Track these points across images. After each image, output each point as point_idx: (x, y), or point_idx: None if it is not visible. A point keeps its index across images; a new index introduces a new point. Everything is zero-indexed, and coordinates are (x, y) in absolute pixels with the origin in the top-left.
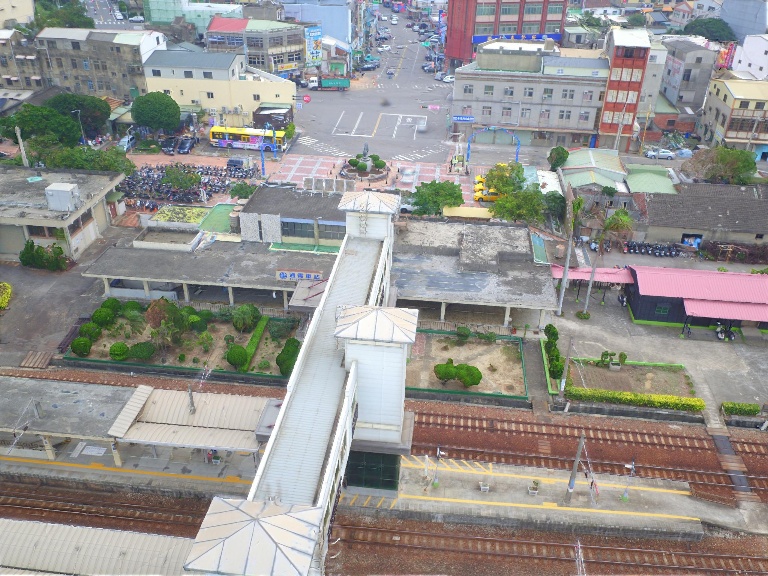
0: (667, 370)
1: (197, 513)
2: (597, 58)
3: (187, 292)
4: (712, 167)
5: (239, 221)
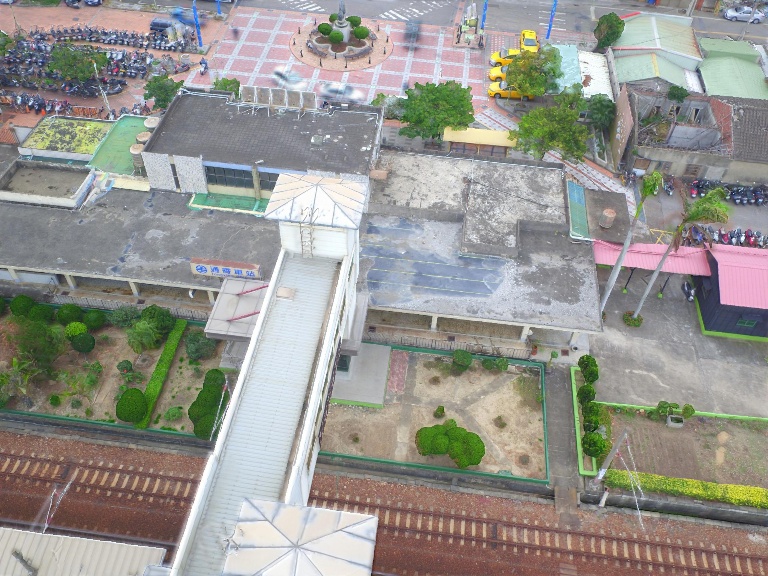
0: (748, 427)
1: None
2: None
3: (69, 278)
4: None
5: None
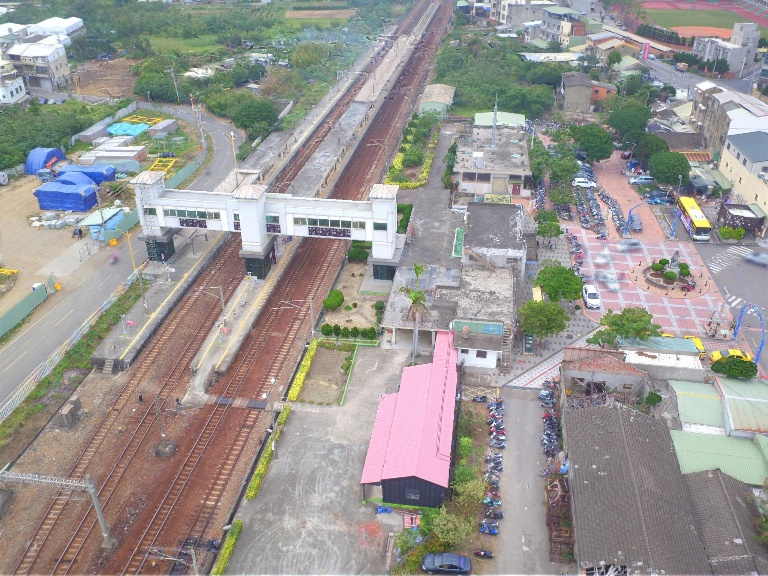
0: None
1: None
2: None
3: None
4: None
5: None
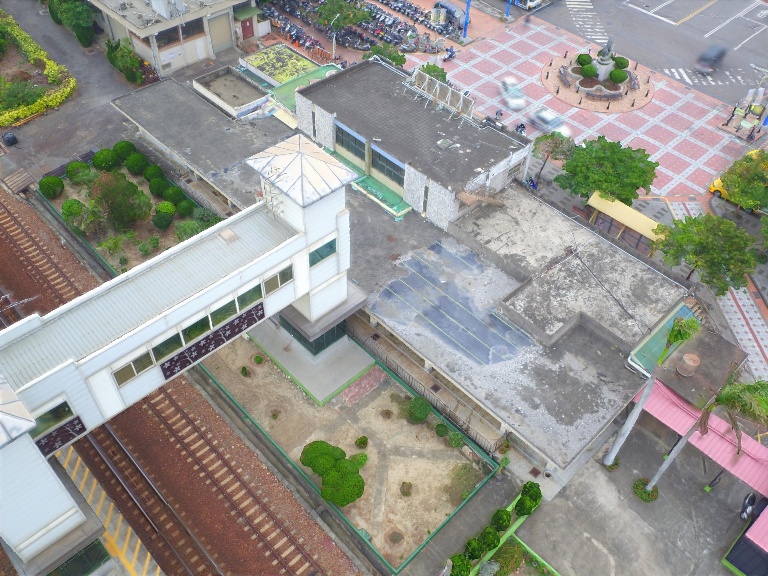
0: None
1: None
2: None
3: None
4: None
5: None
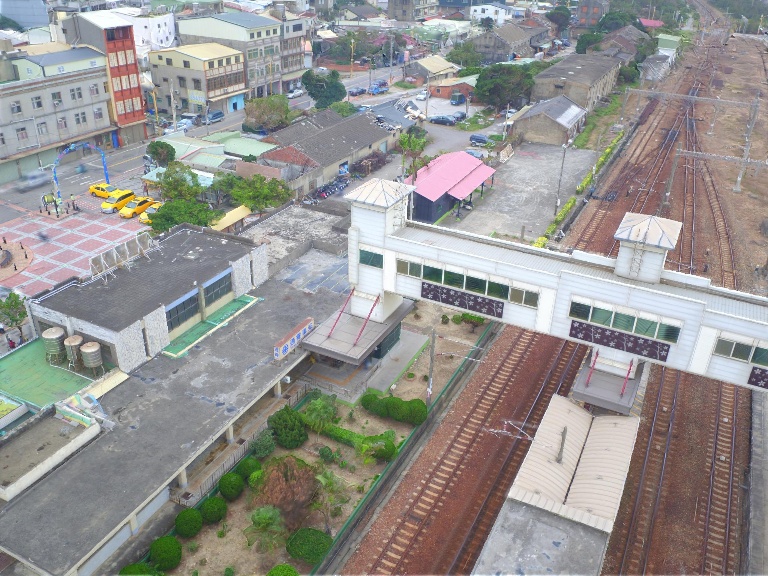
0: None
1: (630, 537)
2: (69, 49)
3: None
4: (270, 116)
5: None
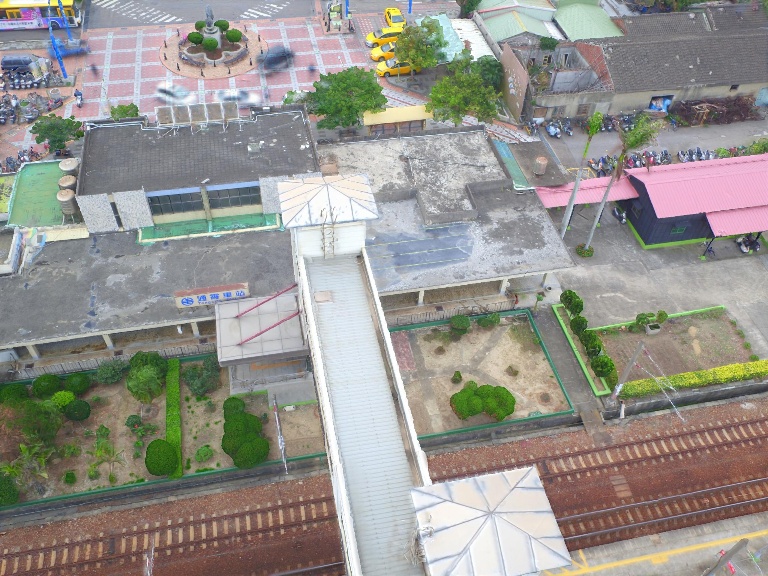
0: (708, 317)
1: None
2: None
3: (32, 348)
4: None
5: (75, 204)
